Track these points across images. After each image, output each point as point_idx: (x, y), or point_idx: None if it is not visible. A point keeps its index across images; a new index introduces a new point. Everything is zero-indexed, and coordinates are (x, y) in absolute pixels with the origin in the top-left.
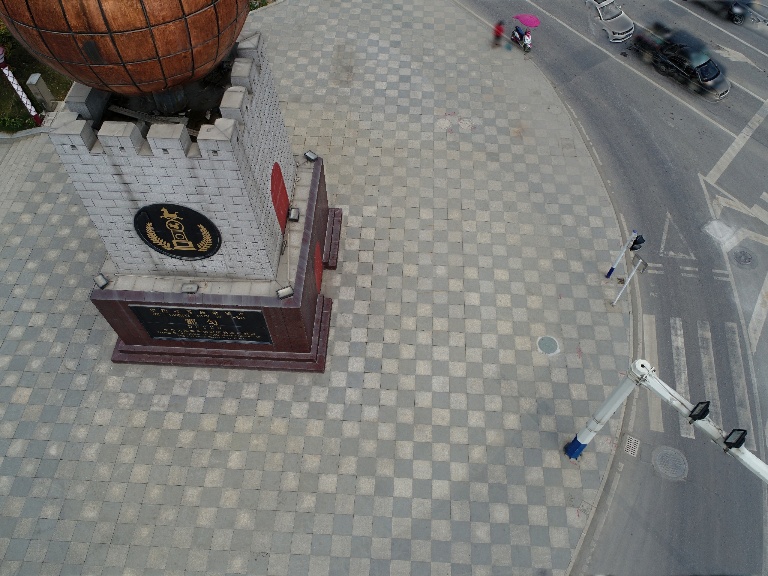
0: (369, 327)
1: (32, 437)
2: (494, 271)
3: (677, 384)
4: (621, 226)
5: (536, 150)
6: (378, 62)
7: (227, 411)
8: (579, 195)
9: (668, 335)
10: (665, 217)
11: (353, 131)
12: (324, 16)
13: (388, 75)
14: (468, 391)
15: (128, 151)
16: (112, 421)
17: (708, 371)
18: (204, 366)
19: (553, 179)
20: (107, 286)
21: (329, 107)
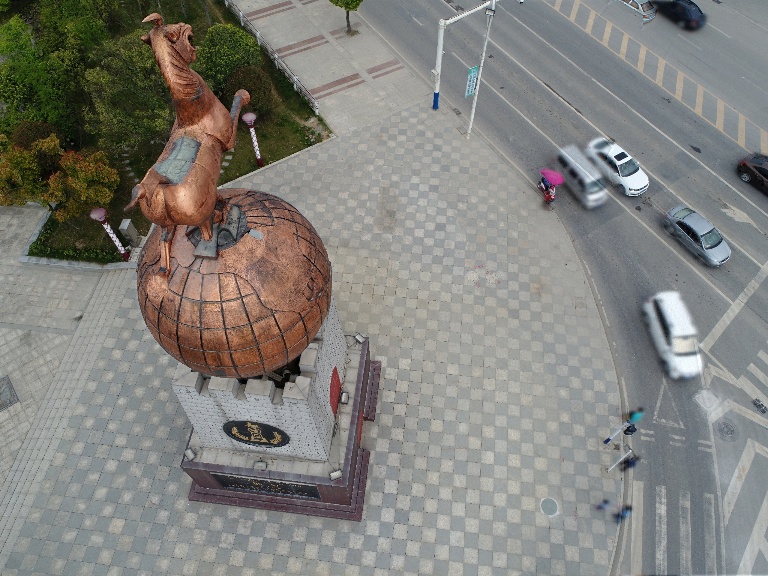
0: (400, 479)
1: (125, 565)
2: (508, 431)
3: (657, 551)
4: (621, 390)
5: (552, 308)
6: (418, 208)
7: (281, 552)
8: (587, 357)
9: (653, 502)
10: (661, 383)
11: (393, 280)
12: (372, 155)
13: (426, 222)
14: (479, 547)
15: (228, 397)
16: (189, 555)
17: (685, 540)
18: (263, 509)
19: (565, 340)
20: (194, 458)
21: (373, 254)
